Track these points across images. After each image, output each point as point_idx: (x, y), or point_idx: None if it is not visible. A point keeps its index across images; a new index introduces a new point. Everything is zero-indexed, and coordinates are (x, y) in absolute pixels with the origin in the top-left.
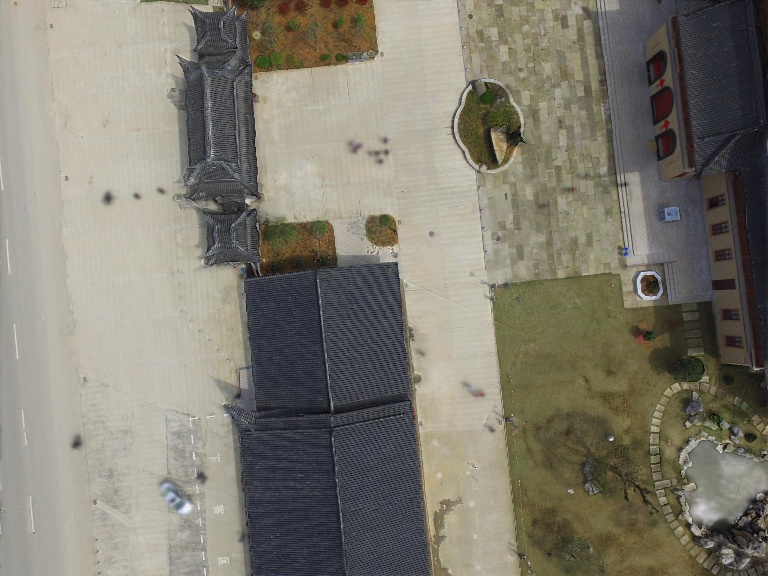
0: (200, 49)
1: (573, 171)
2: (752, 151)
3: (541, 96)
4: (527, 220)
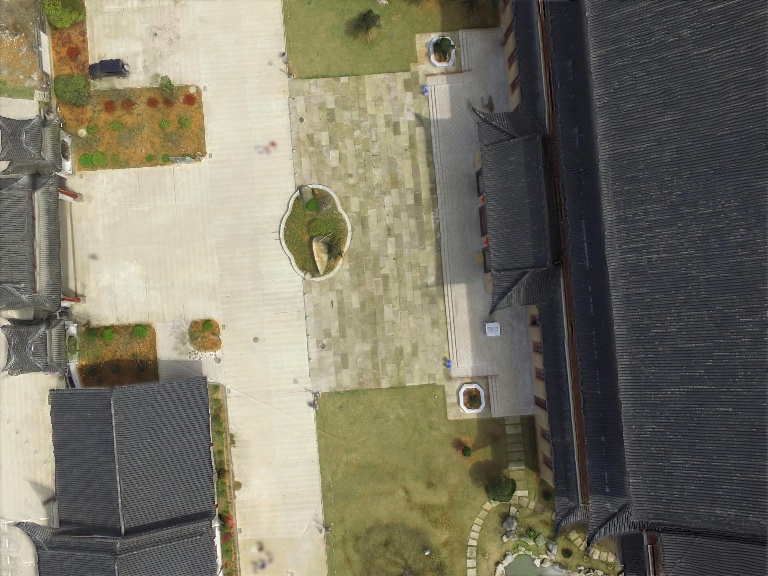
0: (3, 159)
1: (401, 280)
2: (547, 286)
3: (371, 203)
4: (353, 328)
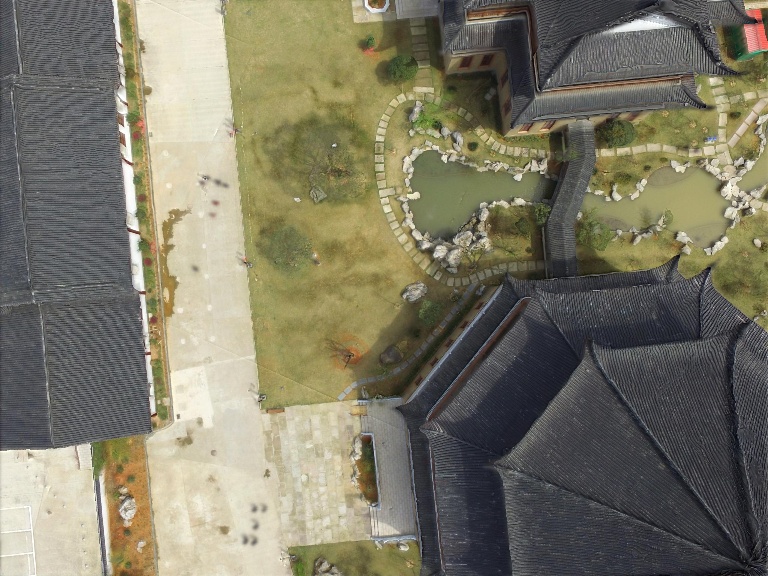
0: None
1: None
2: None
3: None
4: None
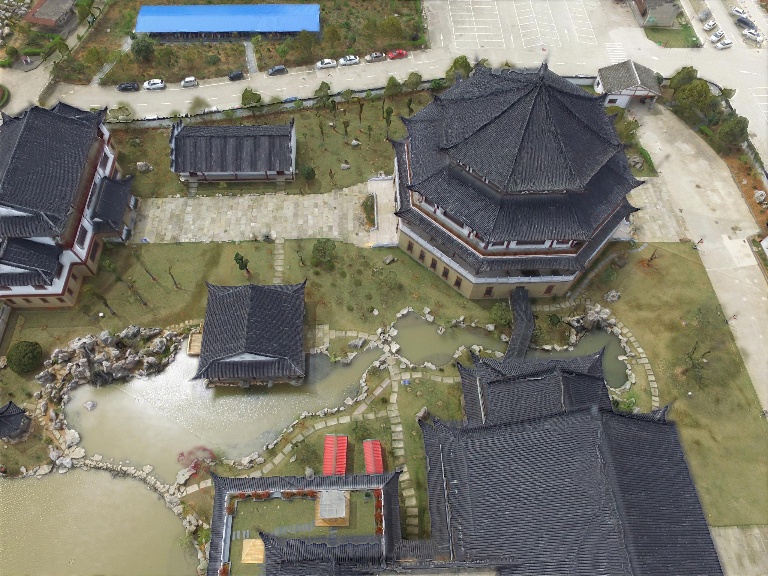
0: None
1: None
2: None
3: None
4: None
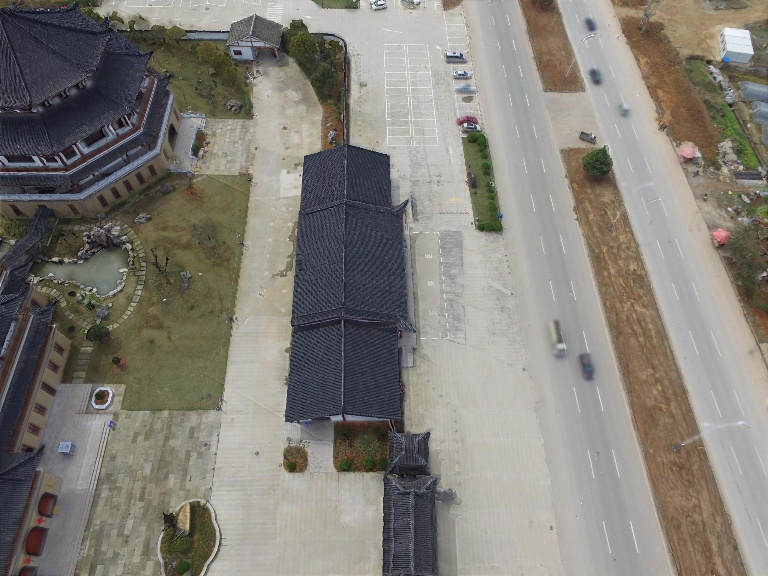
0: None
1: (130, 496)
2: None
3: (136, 568)
4: (179, 458)
